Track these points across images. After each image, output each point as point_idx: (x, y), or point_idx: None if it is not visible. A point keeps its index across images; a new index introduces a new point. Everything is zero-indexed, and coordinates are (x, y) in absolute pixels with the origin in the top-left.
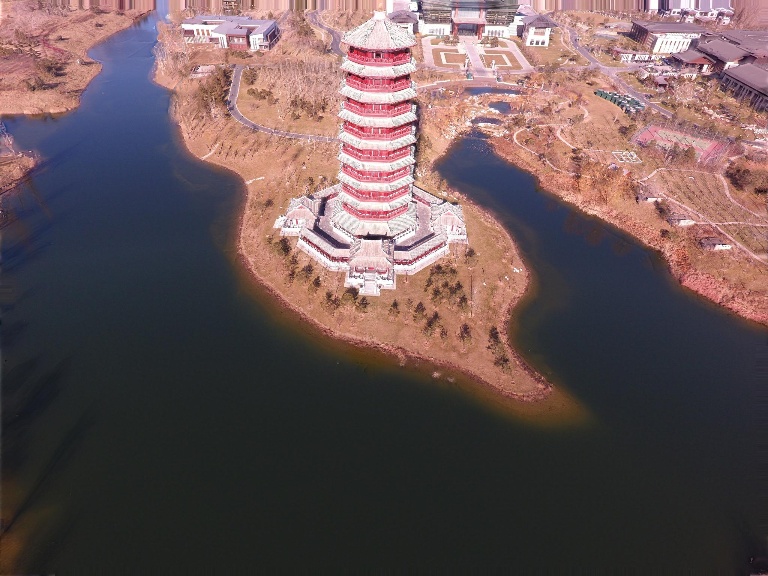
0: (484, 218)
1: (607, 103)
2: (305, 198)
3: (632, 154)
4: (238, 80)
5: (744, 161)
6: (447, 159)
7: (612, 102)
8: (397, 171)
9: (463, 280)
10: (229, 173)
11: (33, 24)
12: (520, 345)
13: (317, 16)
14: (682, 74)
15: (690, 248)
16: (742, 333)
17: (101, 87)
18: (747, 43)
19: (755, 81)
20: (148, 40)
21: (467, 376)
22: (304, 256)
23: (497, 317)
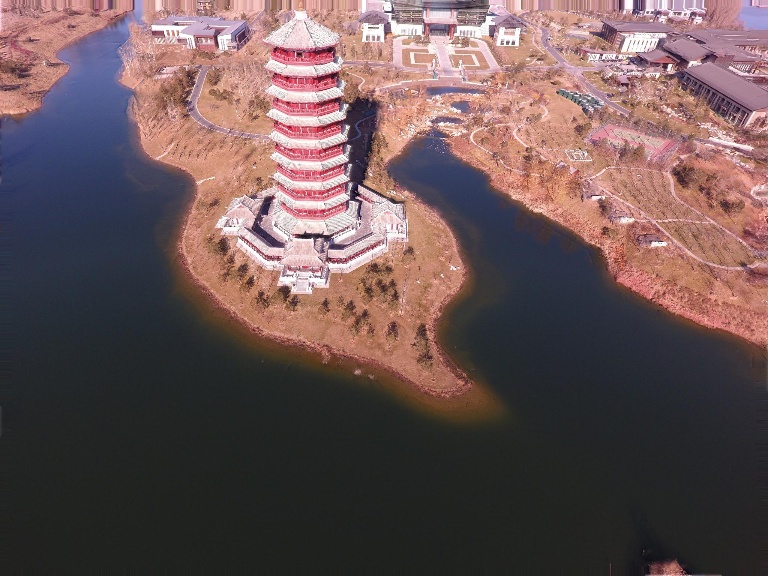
0: (429, 217)
1: (568, 102)
2: (246, 197)
3: (584, 152)
4: (202, 81)
5: (692, 159)
6: (402, 158)
7: (573, 101)
8: (331, 170)
9: (397, 278)
10: (181, 173)
11: (3, 25)
12: (447, 342)
13: (291, 17)
14: (646, 73)
15: (628, 245)
16: (670, 329)
17: (66, 88)
18: (713, 42)
19: (713, 80)
20: (120, 41)
21: (389, 373)
22: (242, 255)
23: (427, 315)
